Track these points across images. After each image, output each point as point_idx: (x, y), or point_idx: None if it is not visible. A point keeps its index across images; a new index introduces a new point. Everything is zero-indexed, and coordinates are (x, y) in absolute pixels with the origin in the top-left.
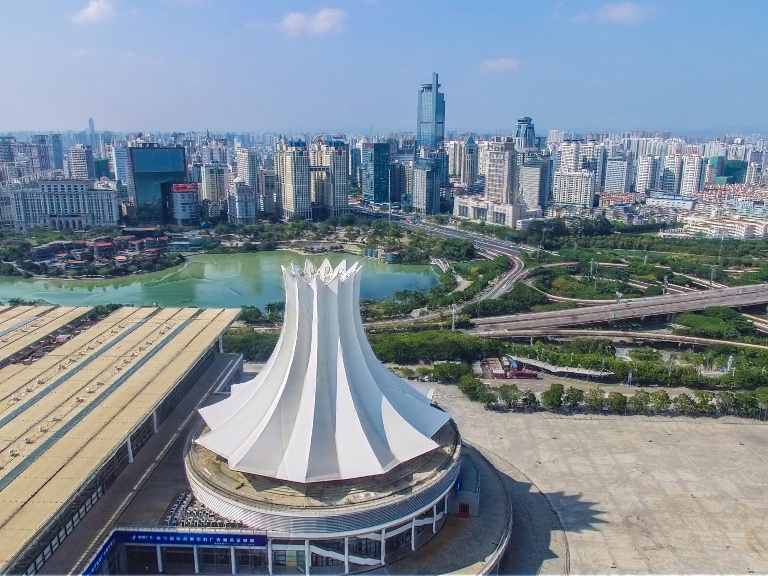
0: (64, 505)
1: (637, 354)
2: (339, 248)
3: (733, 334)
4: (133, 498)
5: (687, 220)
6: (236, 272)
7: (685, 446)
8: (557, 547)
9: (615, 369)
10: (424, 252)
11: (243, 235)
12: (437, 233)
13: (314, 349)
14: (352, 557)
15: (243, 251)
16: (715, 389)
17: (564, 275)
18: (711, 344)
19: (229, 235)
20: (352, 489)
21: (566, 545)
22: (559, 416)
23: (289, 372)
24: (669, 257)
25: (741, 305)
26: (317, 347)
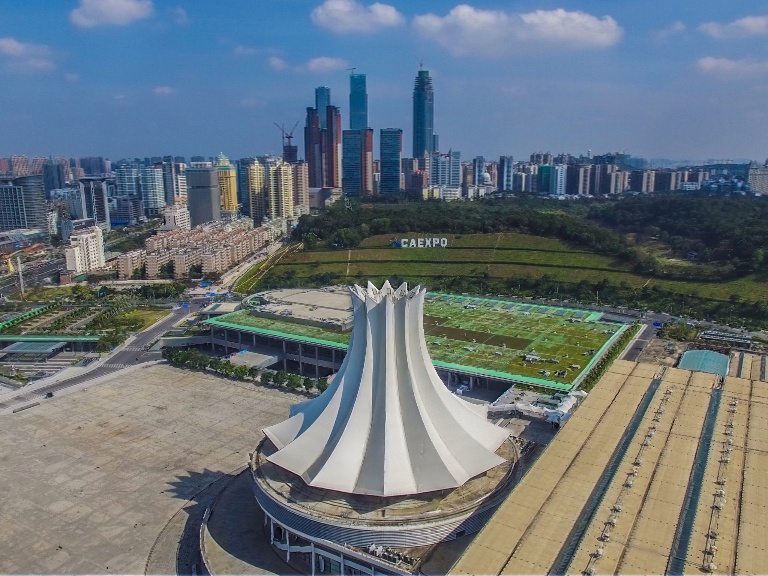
0: None
1: None
2: None
3: None
4: None
5: None
6: None
7: None
8: None
9: None
10: None
11: None
12: None
13: None
14: None
15: None
16: None
17: None
18: None
19: None
20: None
21: None
22: None
23: None
24: None
25: None
26: None
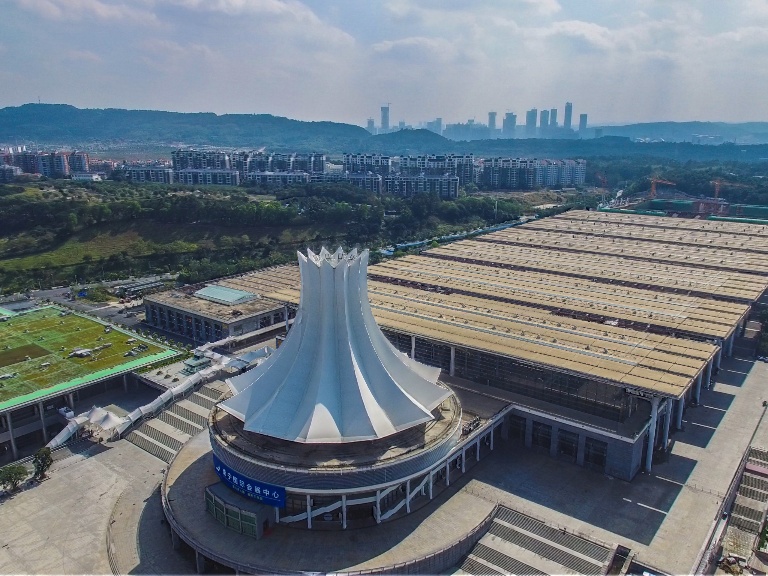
0: None
1: None
2: None
3: None
4: None
5: None
6: None
7: None
8: None
9: None
10: None
11: None
12: None
13: None
14: None
15: None
16: None
17: None
18: None
19: None
20: None
21: None
22: None
23: None
24: None
25: None
26: None
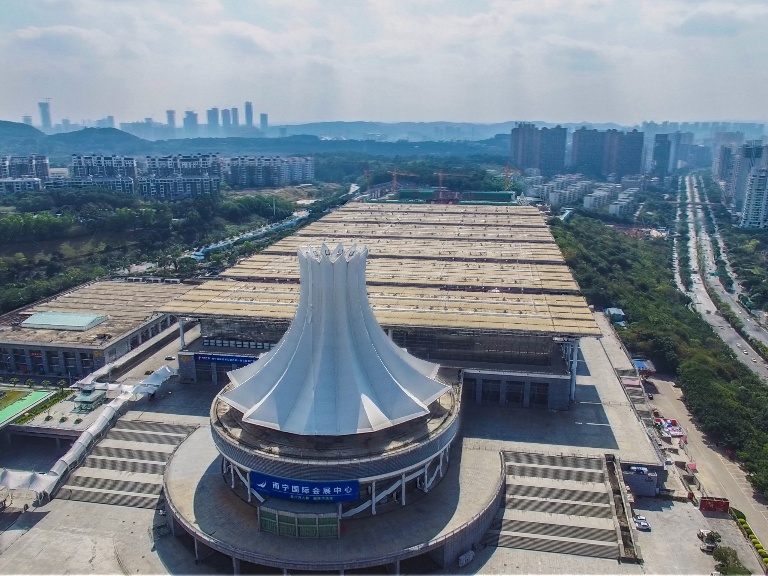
0: (232, 316)
1: None
2: None
3: None
4: None
5: None
6: None
7: None
8: None
9: None
10: None
11: None
12: None
13: None
14: None
15: None
16: None
17: None
18: None
19: None
20: None
21: None
22: None
23: None
24: None
25: None
26: None
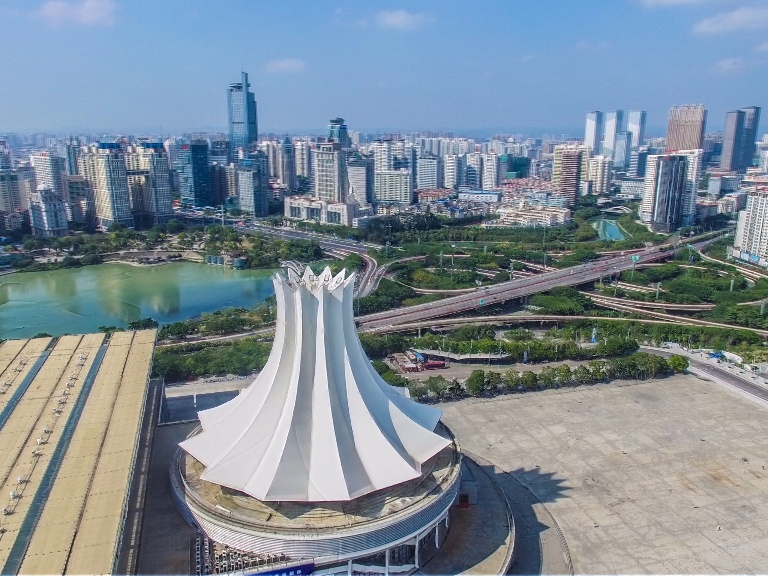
0: None
1: (513, 335)
2: (177, 257)
3: (580, 310)
4: (137, 555)
5: (499, 212)
6: (49, 291)
7: (597, 411)
8: (544, 519)
9: (511, 351)
10: (272, 255)
11: (59, 249)
12: (276, 235)
13: (321, 361)
14: (391, 567)
15: (64, 267)
16: (593, 358)
17: (420, 269)
18: (567, 320)
19: (42, 250)
20: (386, 498)
21: (550, 515)
22: (485, 400)
23: (297, 388)
24: (499, 246)
25: (576, 284)
26: (325, 358)
